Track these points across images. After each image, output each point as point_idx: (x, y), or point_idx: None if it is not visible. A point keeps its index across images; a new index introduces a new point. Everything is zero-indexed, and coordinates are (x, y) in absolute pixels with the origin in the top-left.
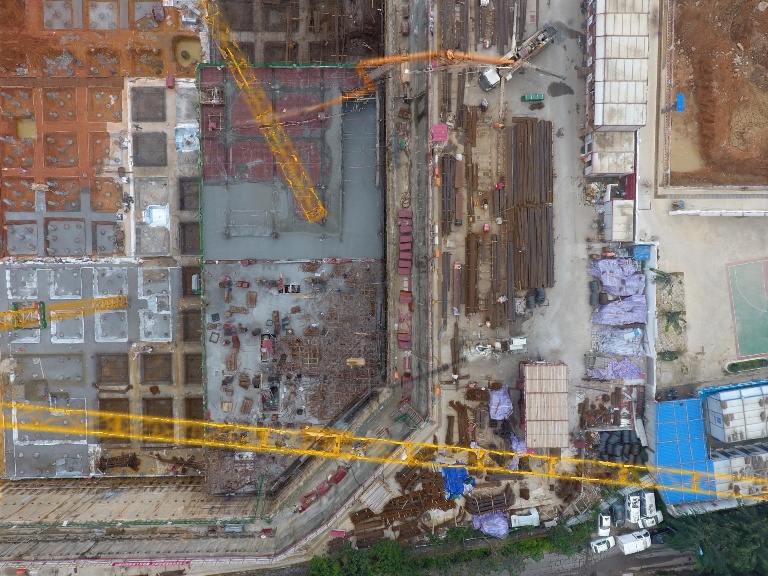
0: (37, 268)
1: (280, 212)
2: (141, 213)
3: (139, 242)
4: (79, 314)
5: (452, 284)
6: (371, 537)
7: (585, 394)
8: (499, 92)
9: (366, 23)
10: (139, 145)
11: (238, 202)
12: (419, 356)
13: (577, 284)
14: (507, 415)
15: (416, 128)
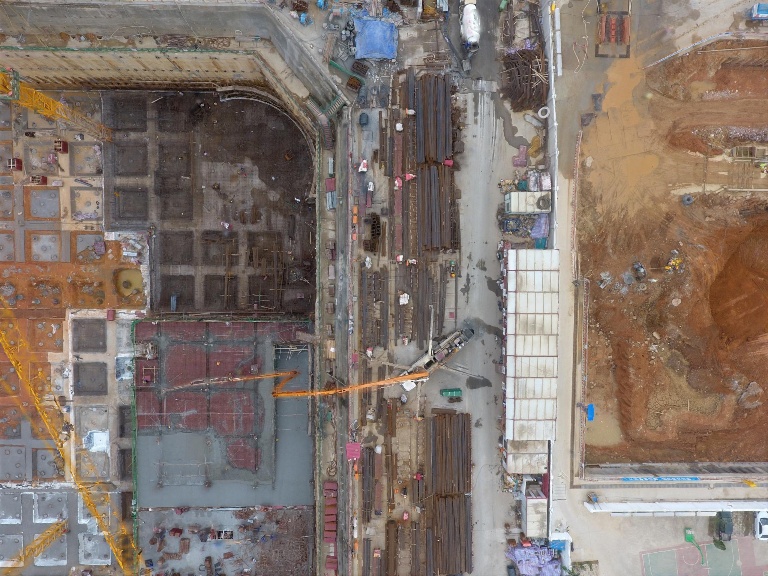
0: None
1: (213, 461)
2: (81, 440)
3: (79, 467)
4: (19, 537)
5: (372, 569)
6: None
7: None
8: None
9: (304, 259)
10: (80, 373)
11: (172, 451)
12: None
13: (495, 567)
14: None
15: (340, 409)
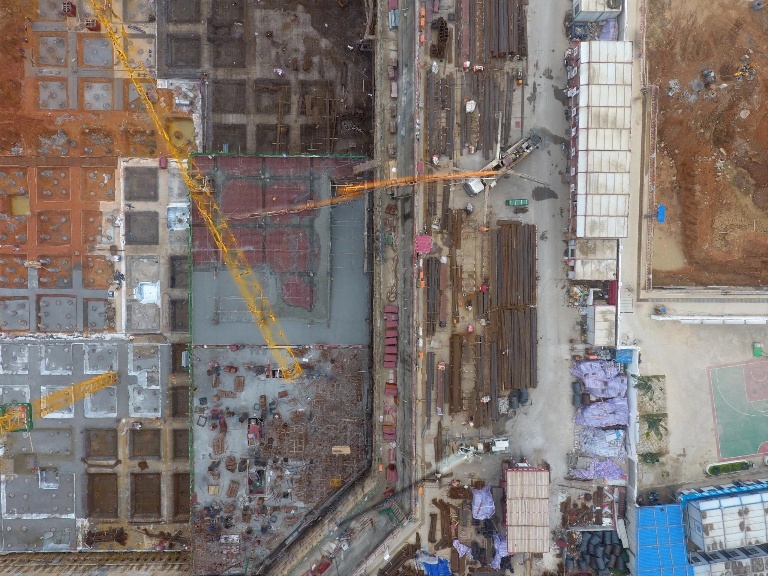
0: (28, 344)
1: (269, 298)
2: (132, 290)
3: (130, 319)
4: (69, 389)
5: (436, 383)
6: None
7: (567, 493)
8: None
9: (357, 107)
10: (131, 223)
11: (227, 288)
12: (403, 451)
13: (560, 384)
14: (489, 515)
15: (402, 227)
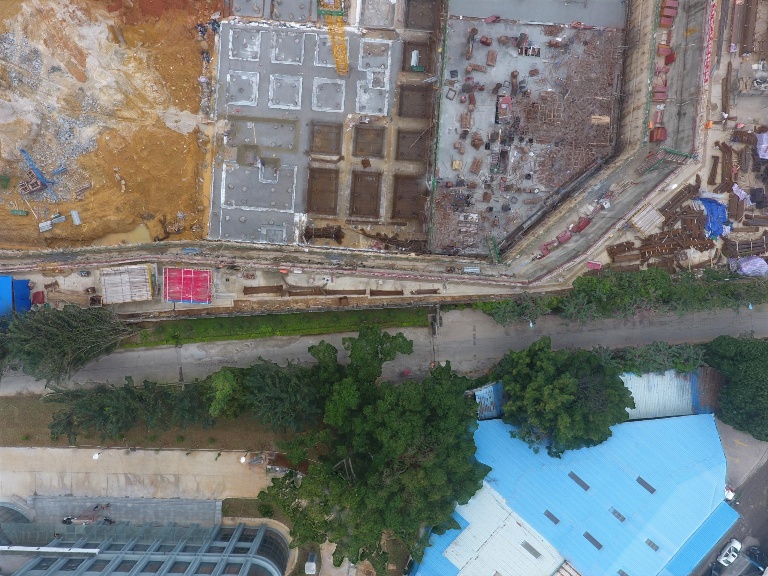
0: (261, 30)
1: None
2: None
3: (363, 13)
4: (297, 82)
5: (730, 22)
6: (627, 271)
7: None
8: None
9: None
10: None
11: None
12: (680, 102)
13: None
14: None
15: None
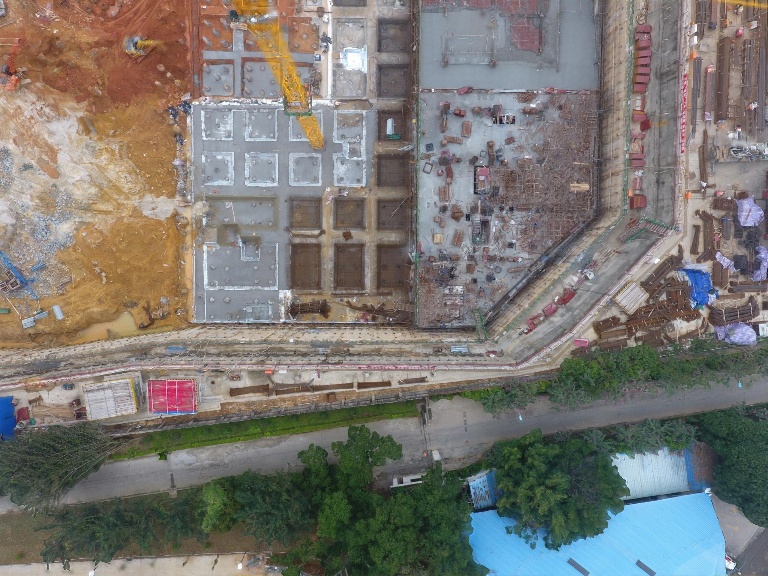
0: (233, 109)
1: (497, 40)
2: (339, 54)
3: (335, 85)
4: (272, 158)
5: (703, 90)
6: (615, 346)
7: None
8: None
9: None
10: None
11: (456, 29)
12: (658, 170)
13: None
14: (758, 222)
15: None
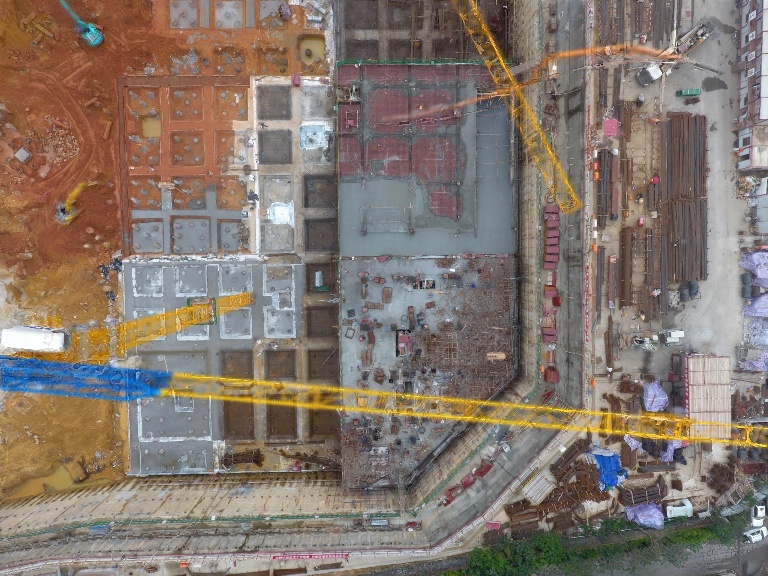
0: (163, 266)
1: (416, 208)
2: (266, 210)
3: (263, 239)
4: None
5: (606, 278)
6: (526, 529)
7: (736, 386)
8: (654, 87)
9: (490, 20)
10: (264, 143)
11: (374, 199)
12: (568, 349)
13: (729, 277)
14: (663, 407)
15: (566, 124)
